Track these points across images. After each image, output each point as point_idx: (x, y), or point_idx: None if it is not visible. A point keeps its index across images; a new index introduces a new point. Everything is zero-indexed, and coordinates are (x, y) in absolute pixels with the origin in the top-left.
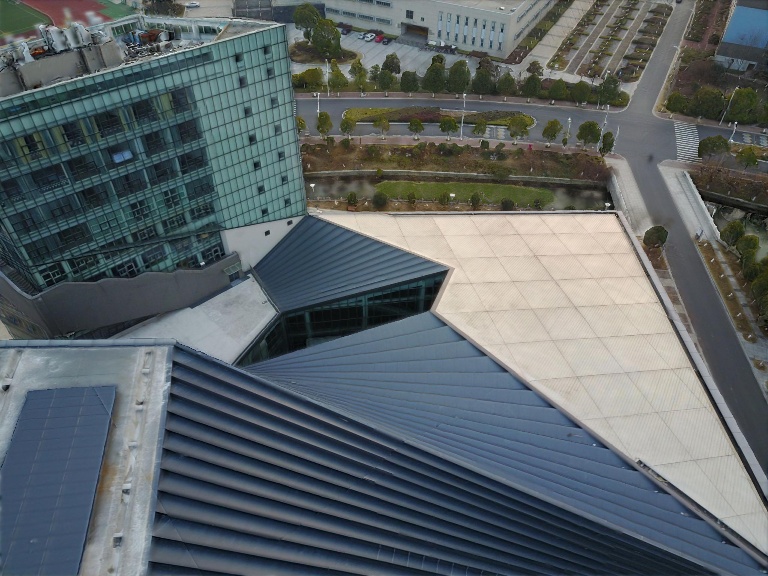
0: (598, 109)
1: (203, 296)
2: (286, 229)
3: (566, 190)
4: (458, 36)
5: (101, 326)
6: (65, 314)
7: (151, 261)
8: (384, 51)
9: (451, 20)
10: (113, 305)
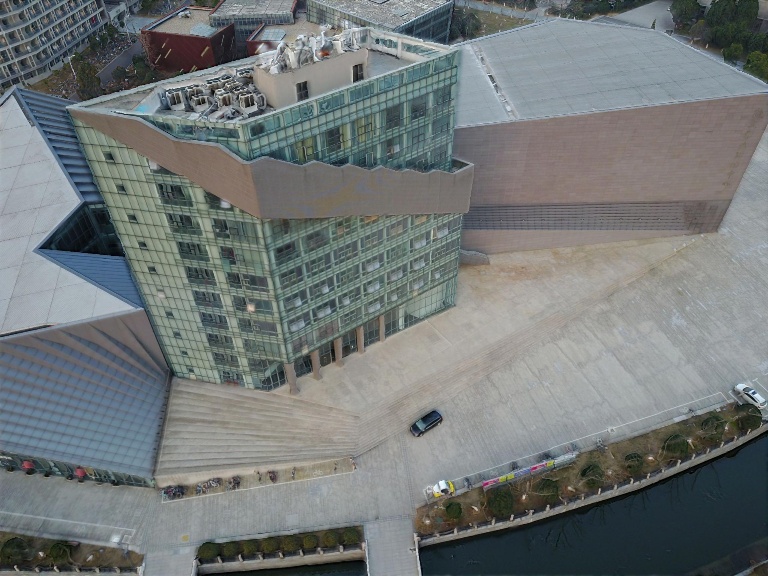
0: None
1: None
2: None
3: None
4: None
5: None
6: None
7: None
8: None
9: None
10: None
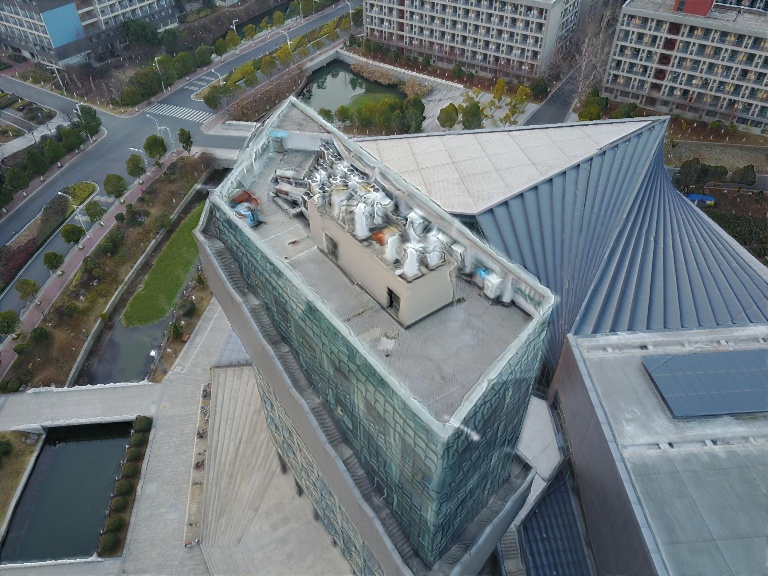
0: (93, 143)
1: None
2: None
3: None
4: None
5: None
6: None
7: None
8: None
9: None
10: None
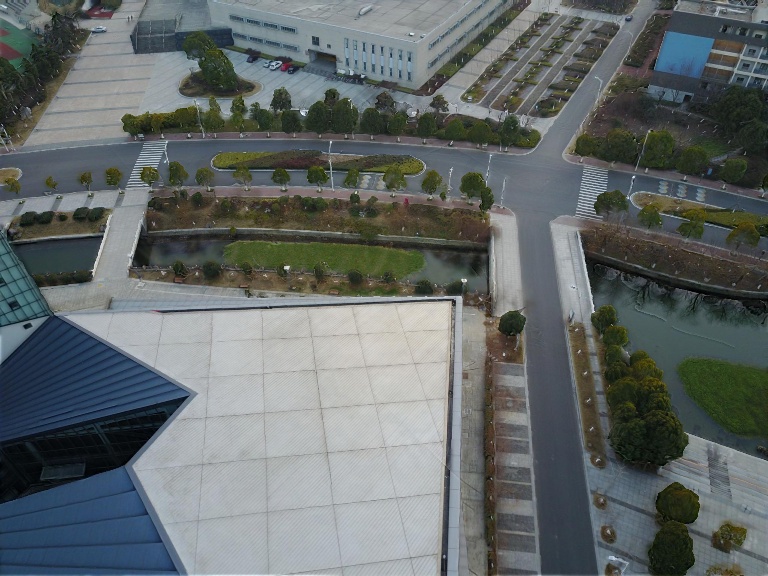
0: (501, 151)
1: None
2: (25, 333)
3: (440, 253)
4: (366, 65)
5: None
6: None
7: None
8: (287, 81)
9: (357, 47)
10: None
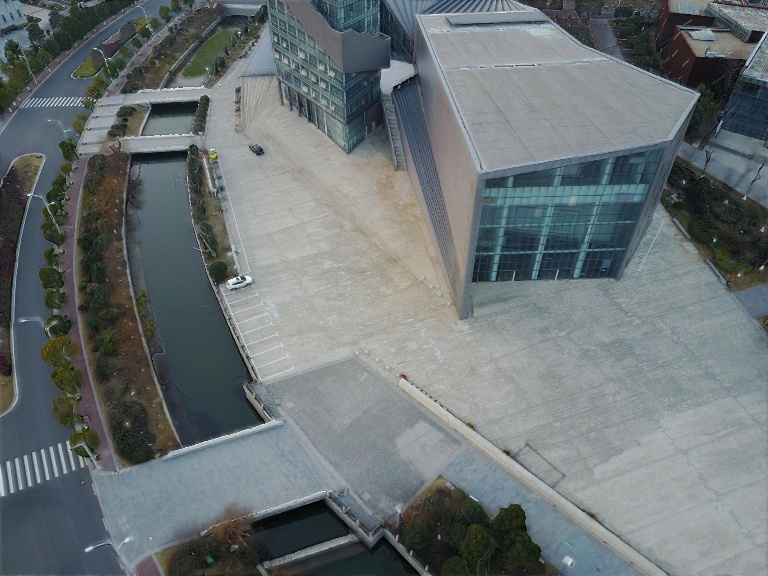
0: (142, 2)
1: None
2: None
3: (222, 26)
4: None
5: None
6: None
7: None
8: None
9: None
10: None
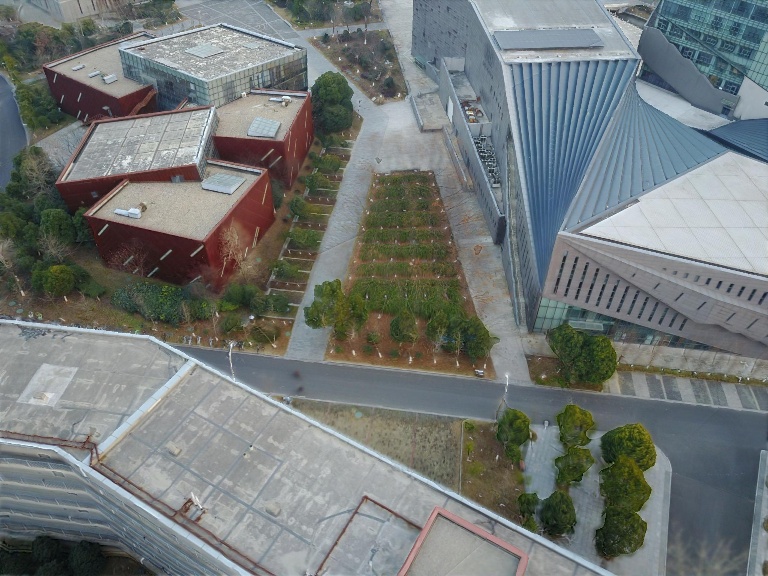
0: None
1: (702, 105)
2: None
3: None
4: None
5: (653, 70)
6: (648, 47)
7: (701, 60)
8: None
9: None
10: (665, 63)
